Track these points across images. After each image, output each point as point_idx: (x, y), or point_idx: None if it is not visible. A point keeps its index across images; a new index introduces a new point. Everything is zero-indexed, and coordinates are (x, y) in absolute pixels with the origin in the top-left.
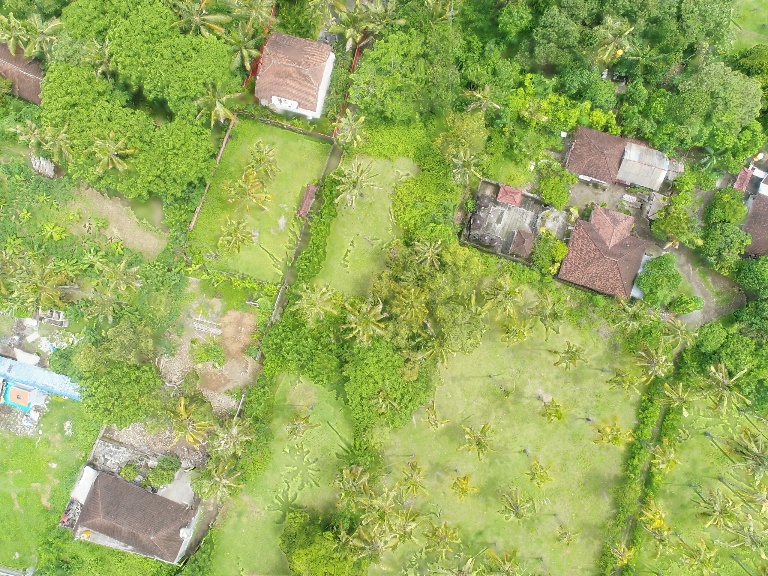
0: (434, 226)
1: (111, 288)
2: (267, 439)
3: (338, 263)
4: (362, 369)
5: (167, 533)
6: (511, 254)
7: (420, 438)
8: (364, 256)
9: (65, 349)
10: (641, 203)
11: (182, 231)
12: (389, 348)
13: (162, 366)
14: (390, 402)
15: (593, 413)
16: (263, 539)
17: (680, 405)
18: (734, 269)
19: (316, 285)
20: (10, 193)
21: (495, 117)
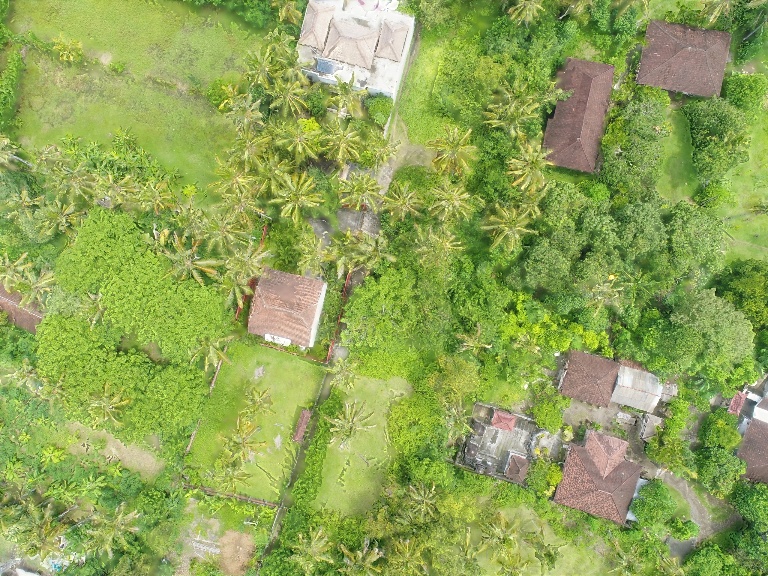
0: (428, 463)
1: (109, 541)
2: None
3: (334, 481)
4: None
5: None
6: None
7: None
8: (360, 476)
9: (66, 572)
10: (635, 419)
11: (179, 455)
12: None
13: None
14: None
15: None
16: None
17: None
18: (729, 493)
19: (313, 503)
20: (9, 414)
21: None
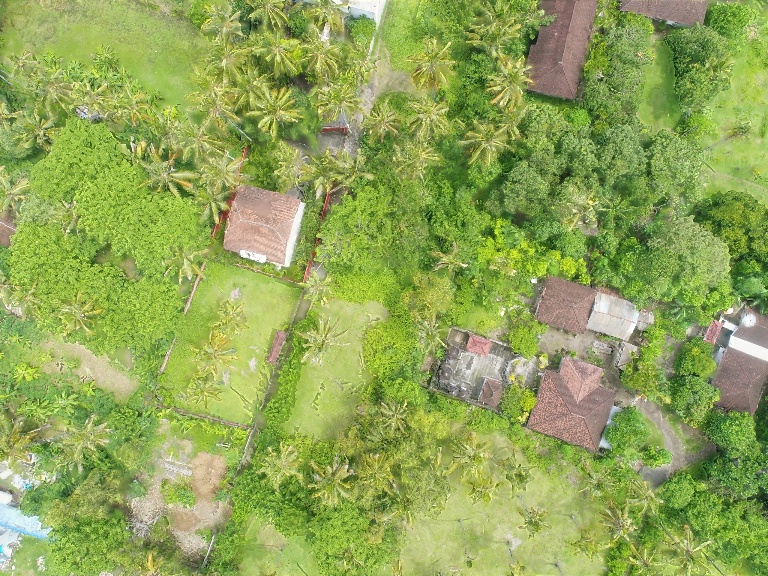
0: (401, 383)
1: (78, 450)
2: None
3: (308, 405)
4: (327, 529)
5: None
6: (480, 402)
7: None
8: (334, 400)
9: (37, 490)
10: (612, 349)
11: (153, 375)
12: (354, 509)
13: (133, 505)
14: (356, 560)
15: (562, 559)
16: None
17: None
18: (703, 422)
19: (286, 427)
20: None
21: (464, 268)
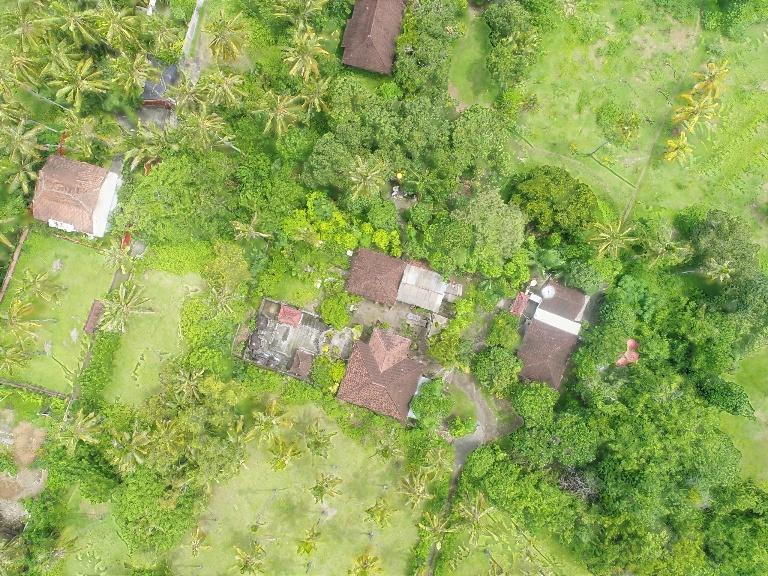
0: (204, 351)
1: None
2: None
3: (129, 376)
4: (125, 495)
5: None
6: None
7: (208, 549)
8: (152, 370)
9: None
10: (427, 321)
11: None
12: (151, 475)
13: None
14: (155, 526)
15: (376, 528)
16: None
17: None
18: (508, 393)
19: (107, 397)
20: None
21: (274, 239)
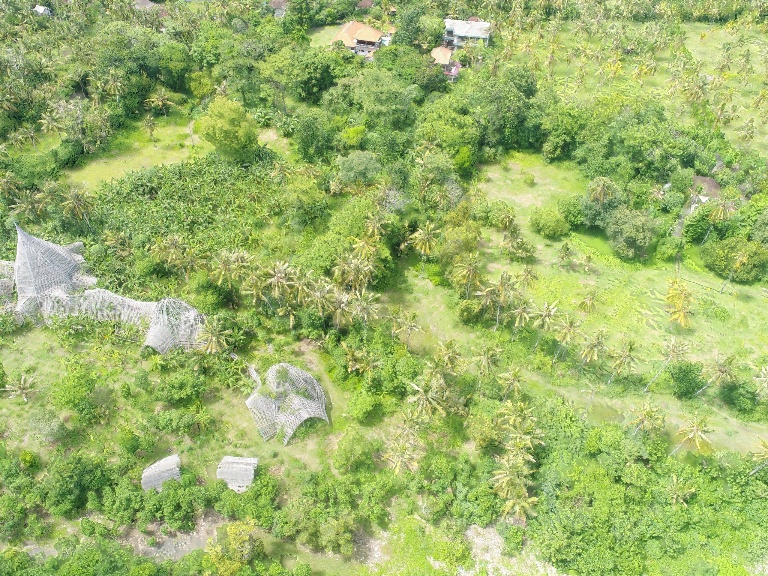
0: None
1: None
2: None
3: None
4: None
5: None
6: None
7: None
8: None
9: None
10: None
11: None
12: None
13: None
14: None
15: None
16: None
17: None
18: None
19: None
20: None
21: None
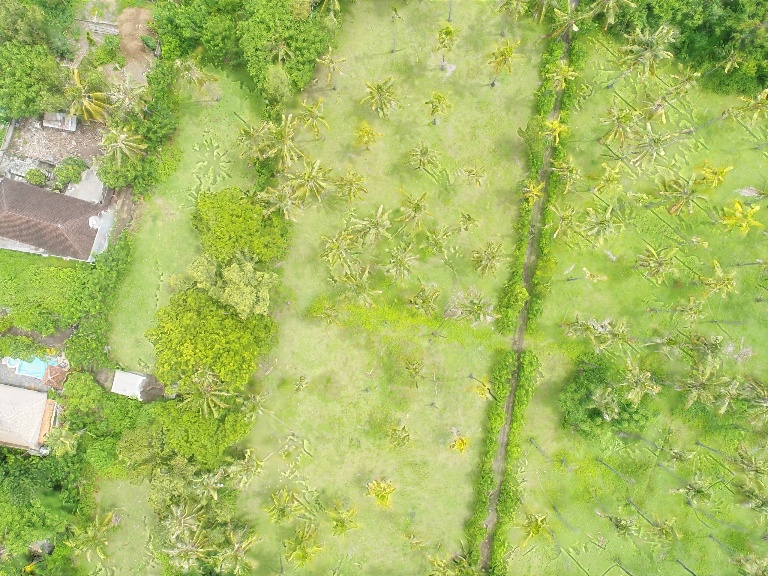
0: None
1: None
2: (171, 122)
3: None
4: (253, 16)
5: (76, 224)
6: None
7: (329, 121)
8: None
9: None
10: None
11: None
12: None
13: None
14: (286, 51)
15: (497, 78)
16: (180, 238)
17: (578, 53)
18: None
19: None
20: None
21: None
